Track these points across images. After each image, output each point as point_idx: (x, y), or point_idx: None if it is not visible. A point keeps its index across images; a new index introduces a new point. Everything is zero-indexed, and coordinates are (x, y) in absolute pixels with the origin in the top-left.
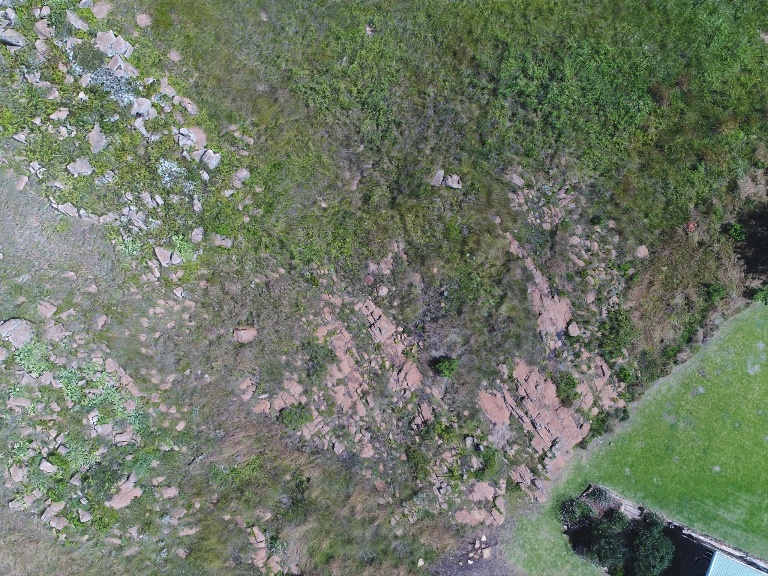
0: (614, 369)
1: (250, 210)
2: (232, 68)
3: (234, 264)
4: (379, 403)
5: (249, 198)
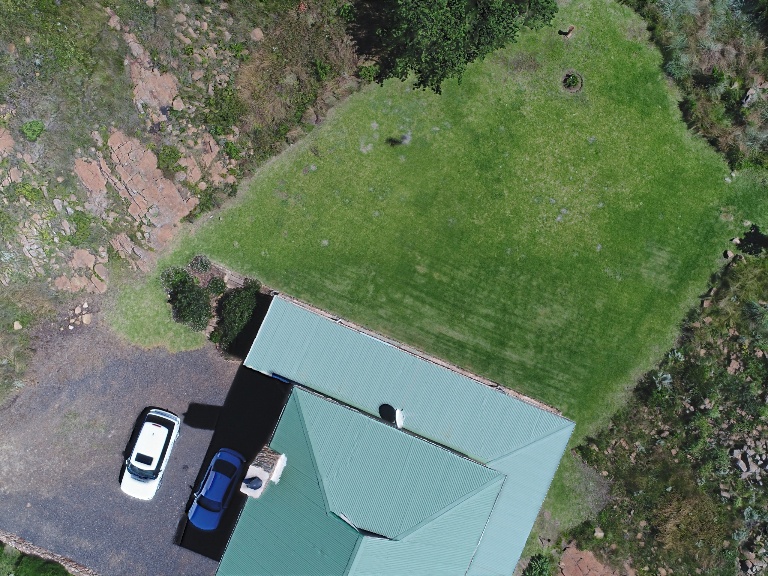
0: (220, 144)
1: None
2: None
3: None
4: None
5: None
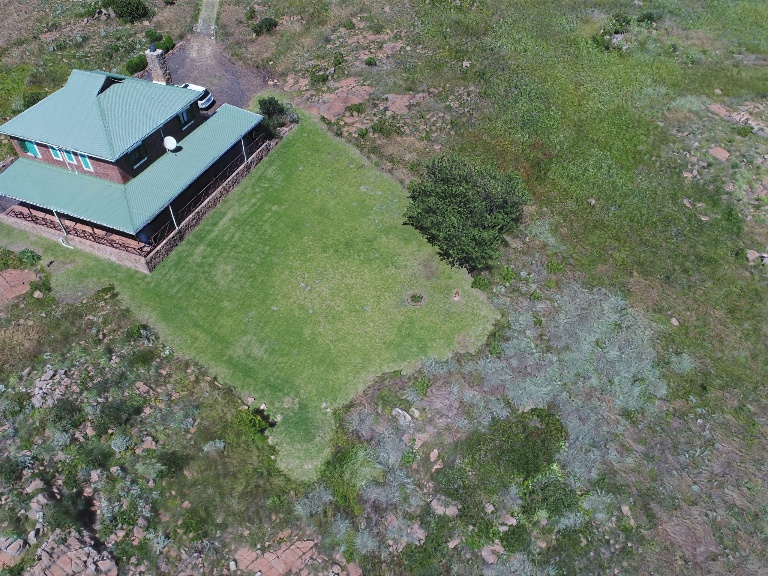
0: None
1: (442, 6)
2: (504, 2)
3: (418, 5)
4: None
5: (448, 7)
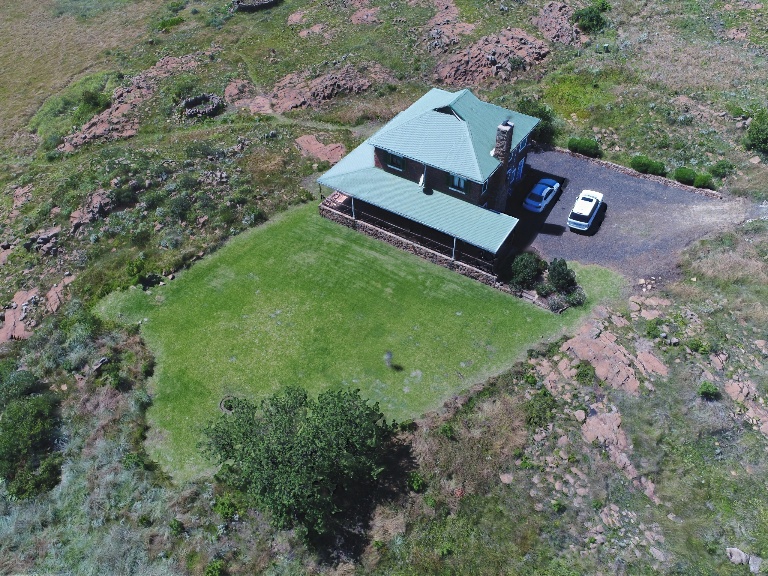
0: None
1: None
2: None
3: None
4: (761, 373)
5: None
